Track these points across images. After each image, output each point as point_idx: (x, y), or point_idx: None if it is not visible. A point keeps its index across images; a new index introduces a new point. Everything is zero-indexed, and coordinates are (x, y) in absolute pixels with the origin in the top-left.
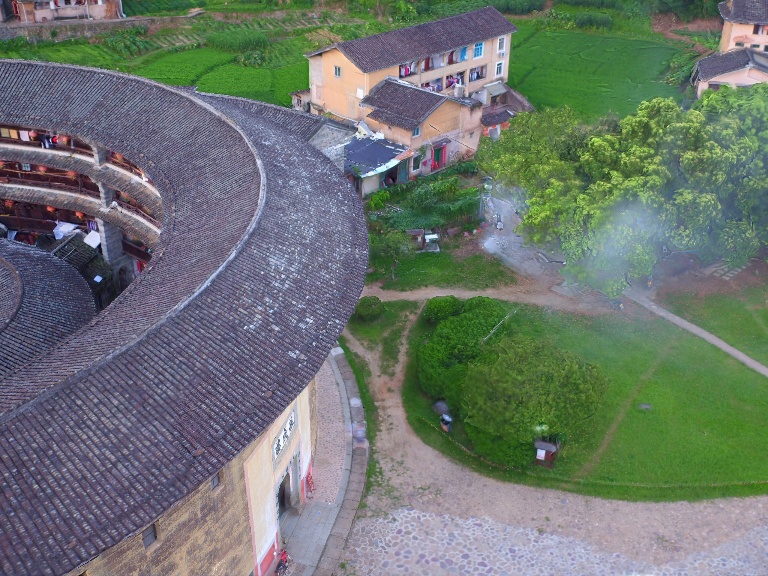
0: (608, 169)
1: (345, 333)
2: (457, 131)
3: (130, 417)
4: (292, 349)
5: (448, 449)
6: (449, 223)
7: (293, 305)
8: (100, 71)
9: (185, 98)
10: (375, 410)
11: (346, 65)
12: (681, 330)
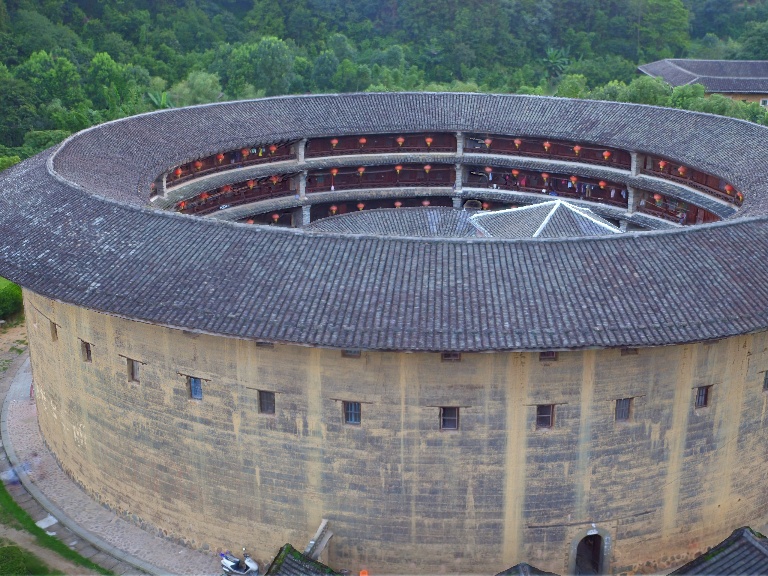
0: None
1: (42, 551)
2: None
3: None
4: None
5: None
6: None
7: None
8: None
9: None
10: None
11: None
12: None
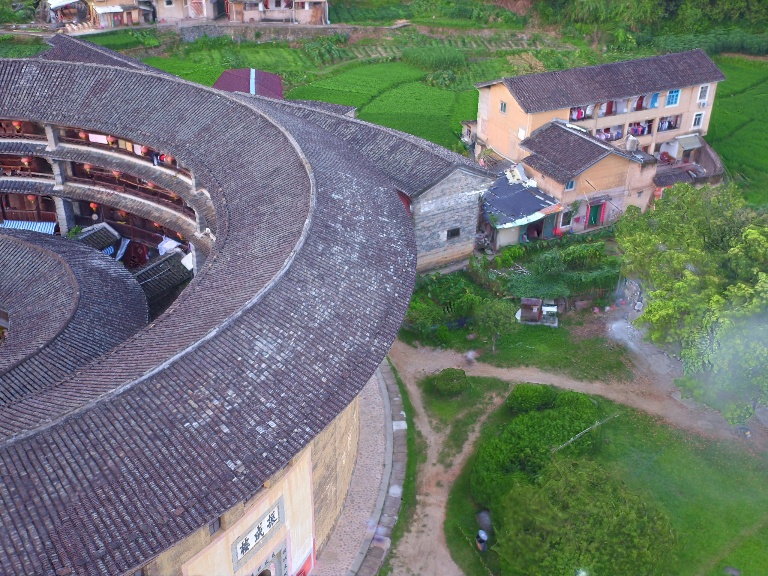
0: (758, 269)
1: (417, 405)
2: (622, 188)
3: (5, 515)
4: (233, 458)
5: (475, 572)
6: (579, 295)
7: (260, 403)
8: (218, 93)
9: (282, 133)
10: (413, 505)
11: (512, 102)
12: None
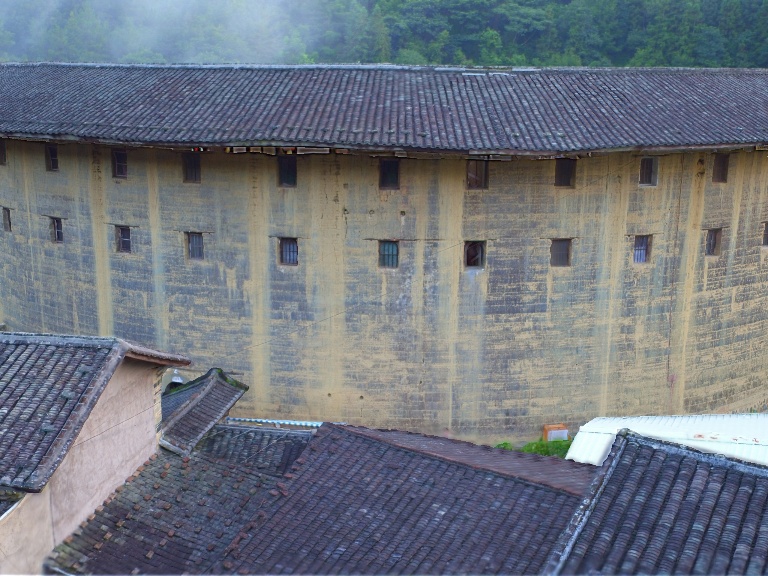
0: None
1: None
2: None
3: None
4: None
5: None
6: None
7: None
8: (106, 65)
9: None
10: None
11: None
12: None
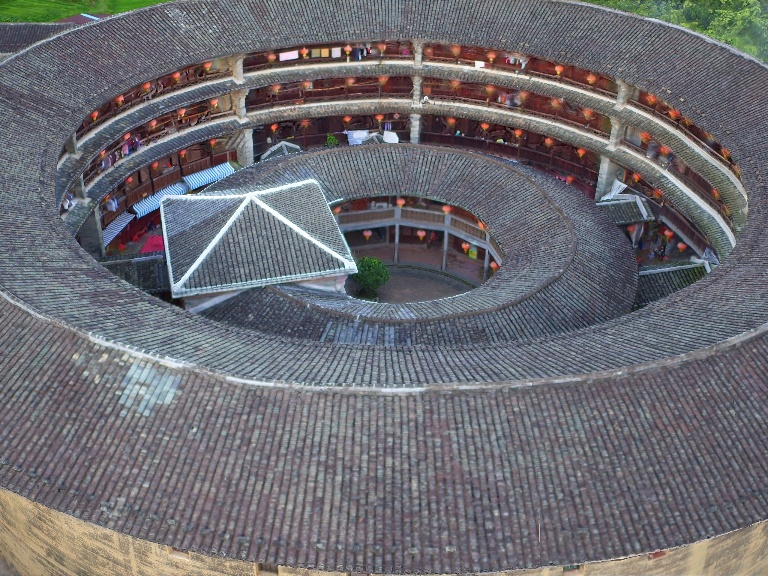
0: (712, 10)
1: None
2: None
3: None
4: None
5: None
6: None
7: None
8: None
9: None
10: None
11: None
12: None
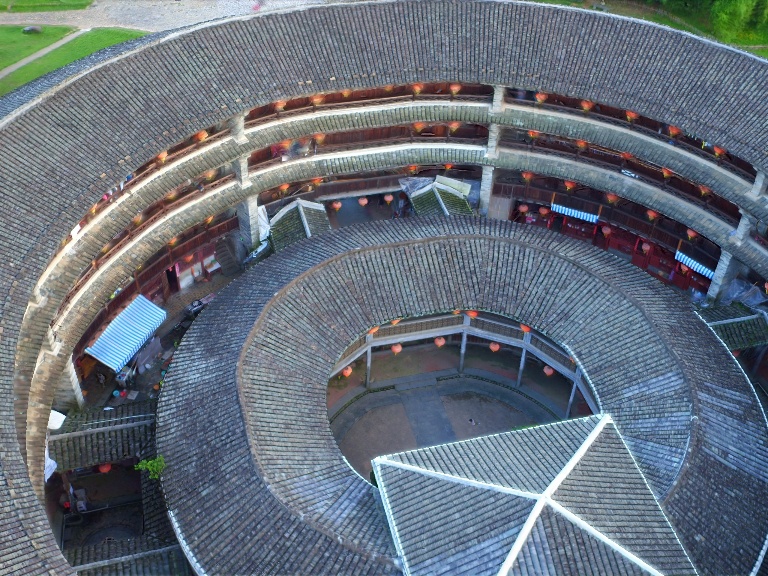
0: None
1: None
2: None
3: None
4: None
5: None
6: None
7: None
8: None
9: None
10: None
11: None
12: (0, 83)
